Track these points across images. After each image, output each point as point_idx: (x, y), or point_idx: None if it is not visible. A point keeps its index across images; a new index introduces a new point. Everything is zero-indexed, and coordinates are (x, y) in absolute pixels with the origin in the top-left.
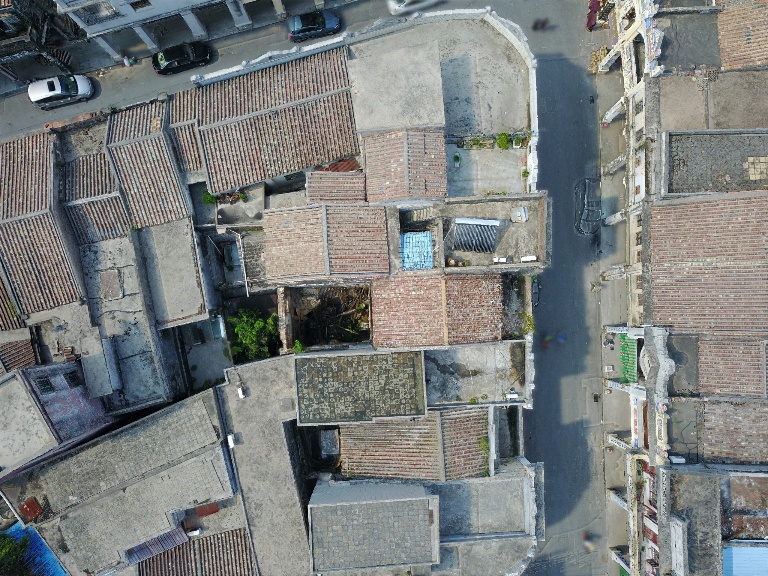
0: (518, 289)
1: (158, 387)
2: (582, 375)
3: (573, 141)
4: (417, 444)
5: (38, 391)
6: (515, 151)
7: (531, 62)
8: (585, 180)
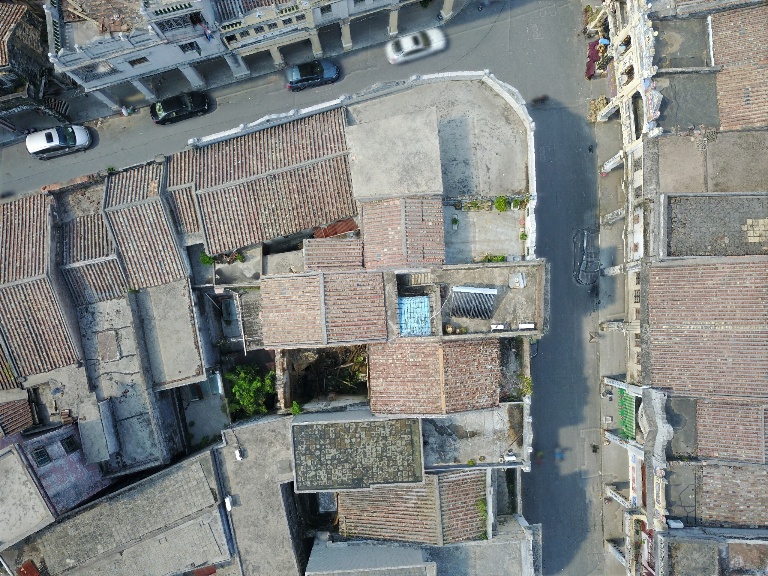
0: (516, 349)
1: (155, 449)
2: (581, 426)
3: (572, 190)
4: (415, 507)
5: (35, 464)
6: (513, 213)
7: (529, 125)
8: (584, 231)
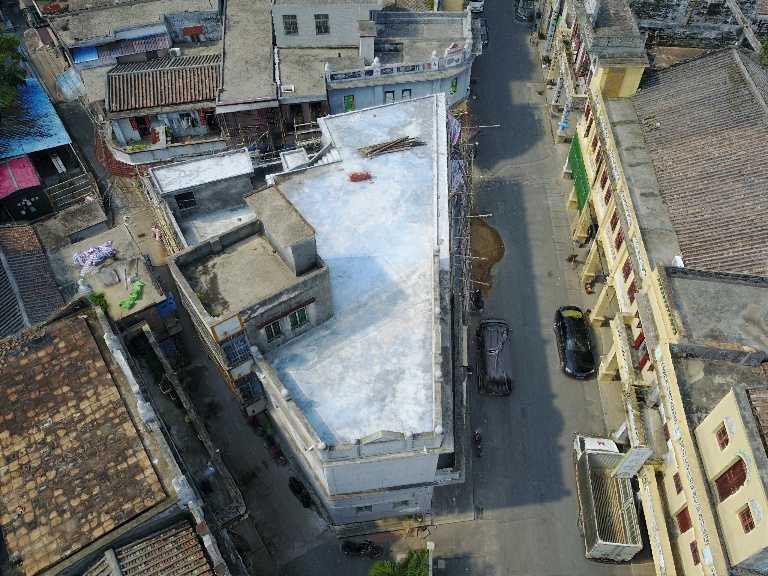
0: None
1: None
2: (527, 81)
3: None
4: None
5: None
6: None
7: None
8: None
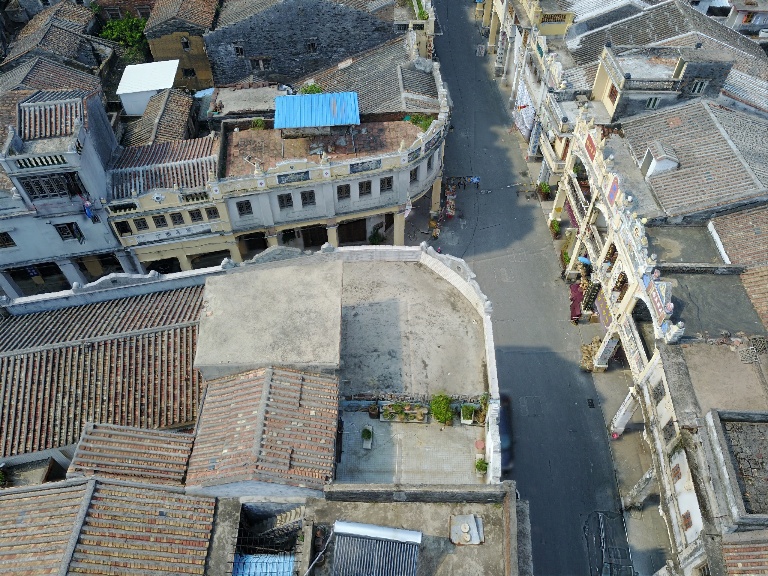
0: None
1: None
2: None
3: (572, 457)
4: None
5: None
6: (465, 430)
7: (483, 306)
8: (597, 513)
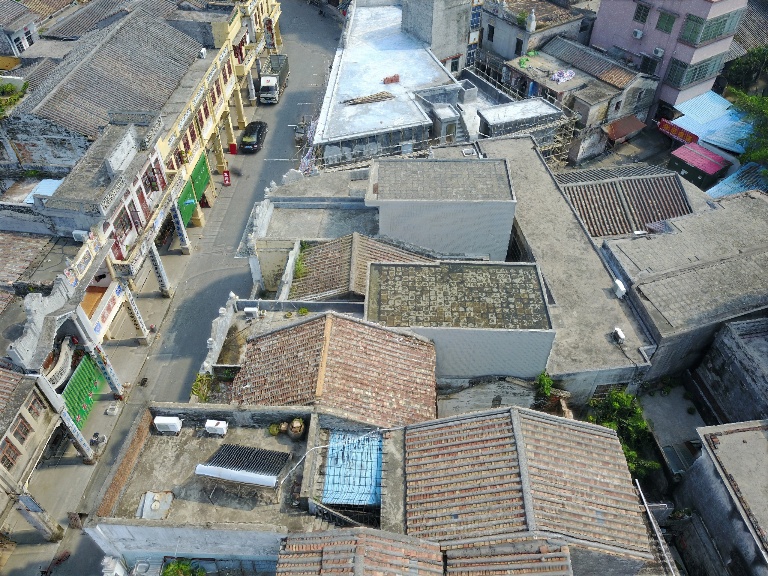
0: None
1: None
2: None
3: None
4: None
5: None
6: None
7: None
8: None
